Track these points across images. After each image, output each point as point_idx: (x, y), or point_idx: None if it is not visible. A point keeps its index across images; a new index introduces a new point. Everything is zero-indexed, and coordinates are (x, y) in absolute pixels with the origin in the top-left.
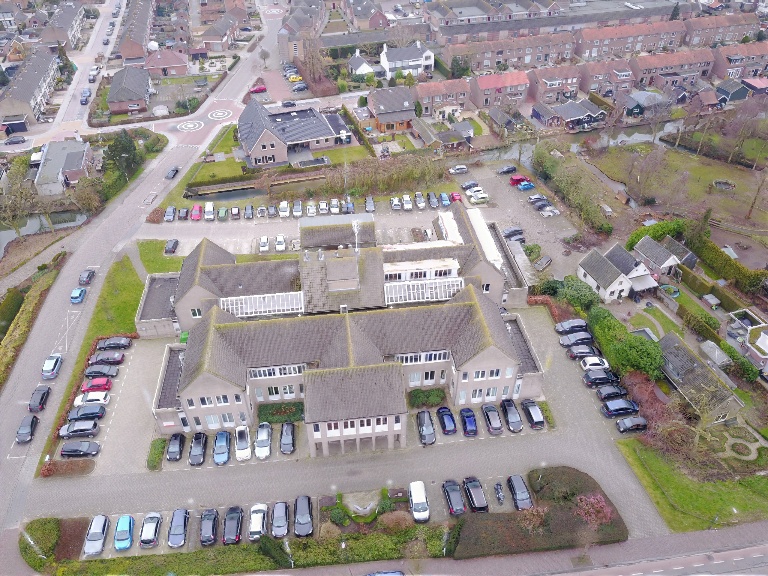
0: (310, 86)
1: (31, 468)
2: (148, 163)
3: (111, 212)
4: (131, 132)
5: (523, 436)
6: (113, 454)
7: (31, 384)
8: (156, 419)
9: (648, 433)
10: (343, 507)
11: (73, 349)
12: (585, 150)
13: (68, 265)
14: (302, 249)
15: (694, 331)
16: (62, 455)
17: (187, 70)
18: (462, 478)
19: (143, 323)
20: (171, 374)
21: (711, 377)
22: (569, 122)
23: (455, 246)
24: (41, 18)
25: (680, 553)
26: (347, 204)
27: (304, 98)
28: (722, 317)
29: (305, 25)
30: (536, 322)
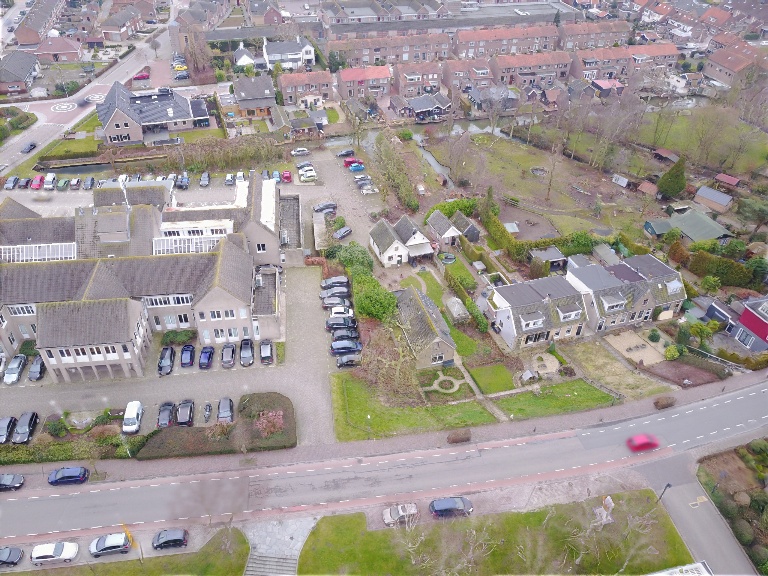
0: (190, 75)
1: None
2: (10, 139)
3: None
4: (1, 110)
5: (251, 369)
6: None
7: None
8: None
9: (360, 368)
10: (64, 422)
11: None
12: (427, 138)
13: None
14: None
15: (453, 291)
16: None
17: (78, 57)
18: None
19: None
20: None
21: (427, 322)
22: (420, 113)
23: (233, 209)
24: None
25: (336, 457)
26: (182, 178)
27: (182, 85)
28: (484, 280)
29: (199, 19)
30: (307, 279)
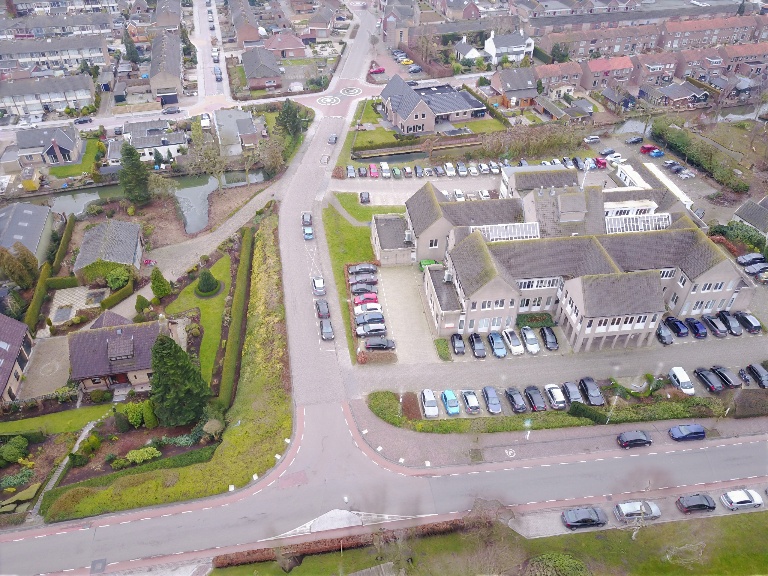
0: (426, 68)
1: (346, 358)
2: (306, 131)
3: (296, 170)
4: (280, 104)
5: (744, 338)
6: (407, 349)
7: (307, 299)
8: (442, 320)
9: None
10: None
11: (327, 274)
12: (696, 126)
13: (283, 210)
14: (518, 191)
15: None
16: (368, 348)
17: (304, 53)
18: (707, 367)
19: (387, 252)
20: (439, 288)
21: None
22: (676, 102)
23: (651, 189)
24: (143, 5)
25: None
26: (506, 166)
27: (423, 79)
28: None
29: (406, 14)
30: None
